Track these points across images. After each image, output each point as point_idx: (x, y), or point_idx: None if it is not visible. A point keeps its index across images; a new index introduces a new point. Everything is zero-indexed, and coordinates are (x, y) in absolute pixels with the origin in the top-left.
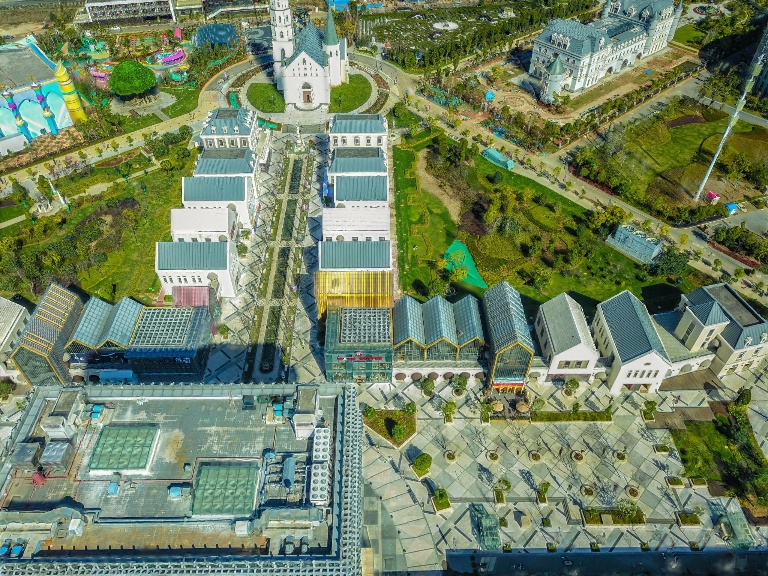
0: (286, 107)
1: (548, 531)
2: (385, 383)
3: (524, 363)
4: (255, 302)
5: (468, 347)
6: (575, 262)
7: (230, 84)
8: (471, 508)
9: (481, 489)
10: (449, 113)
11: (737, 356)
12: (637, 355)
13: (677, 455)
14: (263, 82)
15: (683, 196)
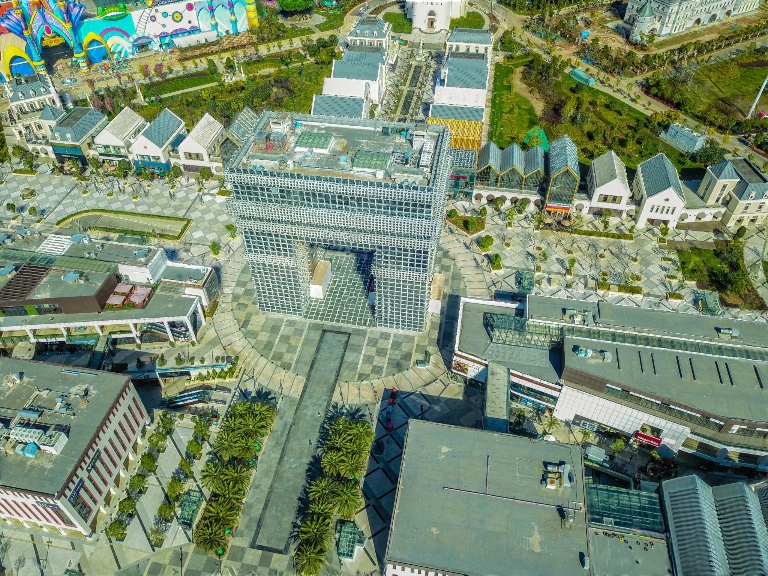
0: (413, 30)
1: (569, 291)
2: (467, 202)
3: (571, 189)
4: None
5: (531, 178)
6: (629, 145)
7: (369, 12)
8: (517, 273)
9: (526, 264)
10: (547, 41)
11: (743, 208)
12: (659, 191)
13: (678, 264)
14: (396, 12)
15: (737, 115)
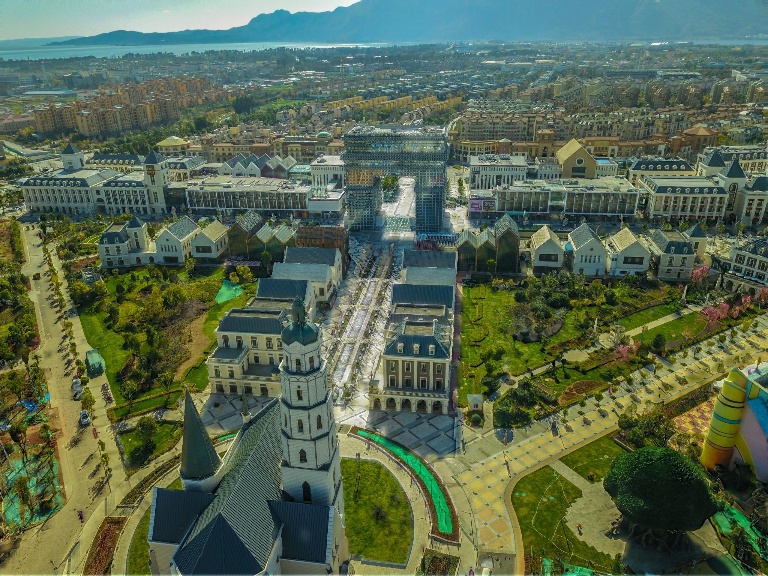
0: None
1: None
2: None
3: None
4: (390, 280)
5: None
6: None
7: None
8: None
9: None
10: None
11: None
12: (192, 222)
13: None
14: (377, 569)
15: None
